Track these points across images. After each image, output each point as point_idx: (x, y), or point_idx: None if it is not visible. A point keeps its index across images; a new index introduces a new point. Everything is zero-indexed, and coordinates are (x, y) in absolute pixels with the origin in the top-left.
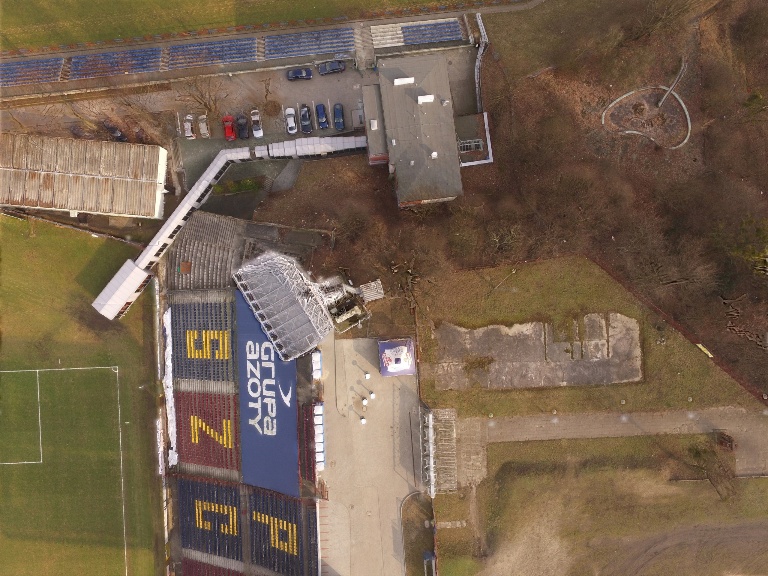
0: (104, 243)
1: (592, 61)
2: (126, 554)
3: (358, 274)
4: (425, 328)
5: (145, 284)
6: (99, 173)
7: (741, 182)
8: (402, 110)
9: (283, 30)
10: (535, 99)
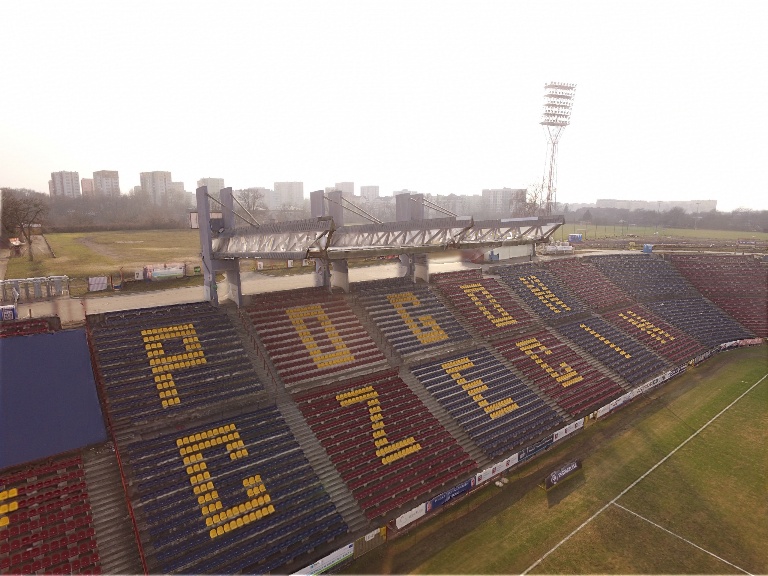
0: None
1: None
2: None
3: None
4: None
5: None
6: None
7: None
8: None
9: None
10: None
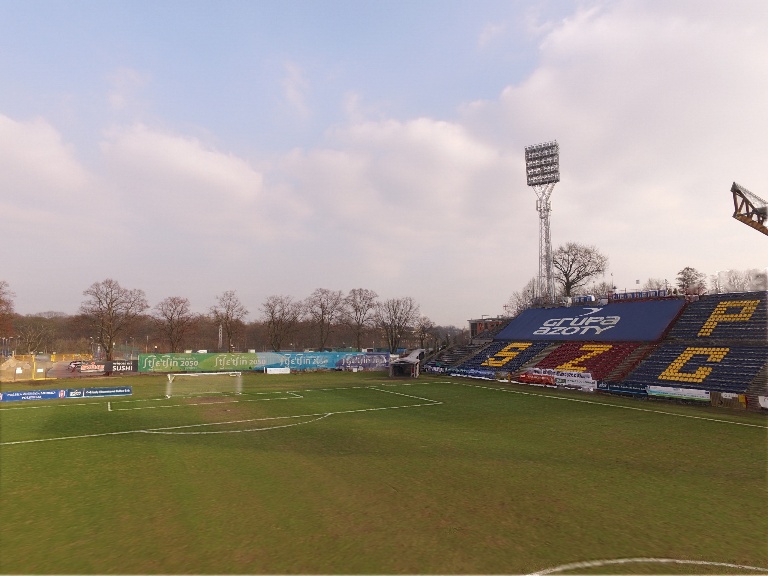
0: None
1: None
2: (697, 417)
3: None
4: None
5: None
6: None
7: None
8: None
9: None
10: None
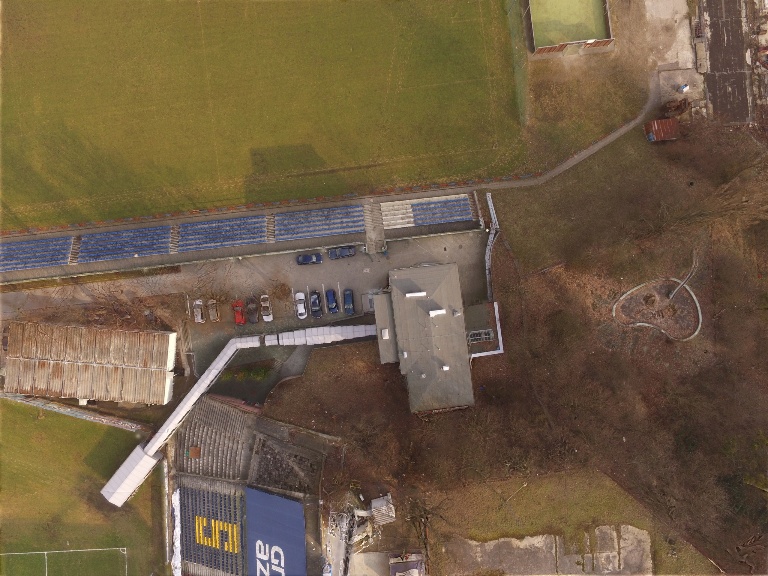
0: None
1: (603, 257)
2: None
3: (369, 487)
4: (436, 541)
5: (154, 466)
6: (108, 361)
7: (752, 370)
8: (414, 321)
9: (293, 206)
10: (546, 292)
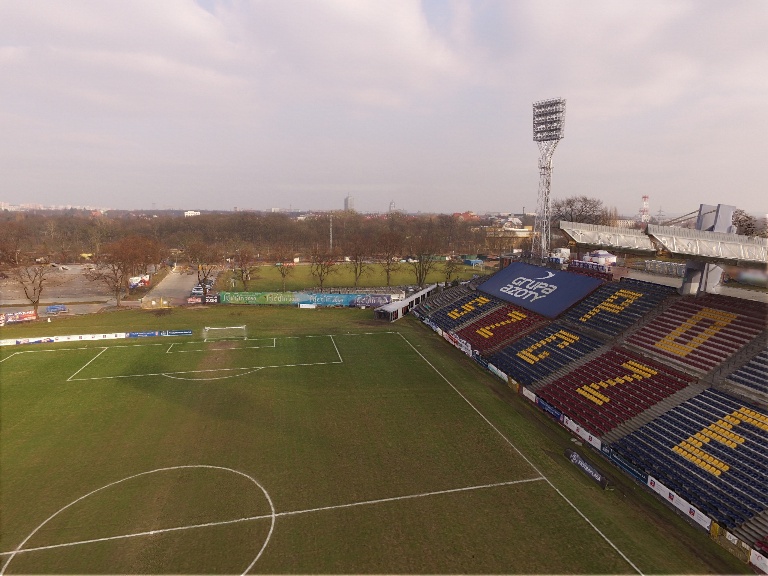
0: None
1: None
2: None
3: None
4: None
5: (404, 314)
6: None
7: None
8: None
9: None
10: None
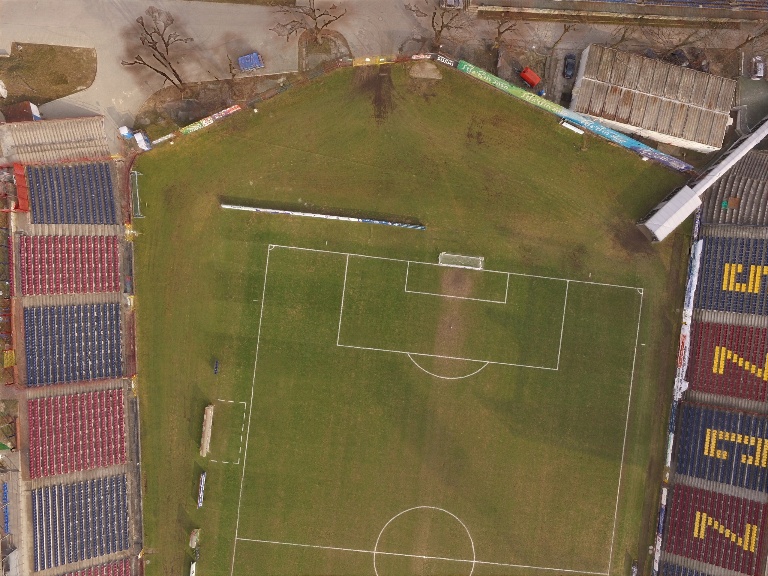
0: (649, 167)
1: None
2: (621, 471)
3: None
4: None
5: None
6: (676, 98)
7: None
8: None
9: None
10: None
